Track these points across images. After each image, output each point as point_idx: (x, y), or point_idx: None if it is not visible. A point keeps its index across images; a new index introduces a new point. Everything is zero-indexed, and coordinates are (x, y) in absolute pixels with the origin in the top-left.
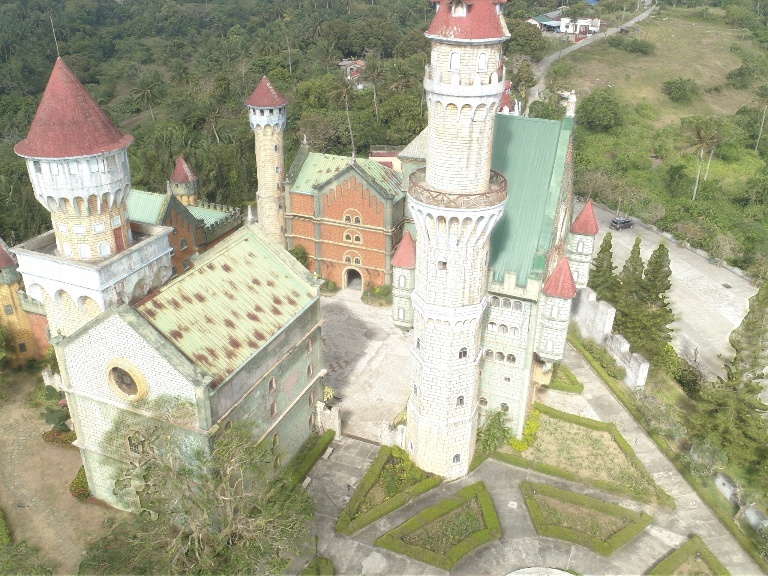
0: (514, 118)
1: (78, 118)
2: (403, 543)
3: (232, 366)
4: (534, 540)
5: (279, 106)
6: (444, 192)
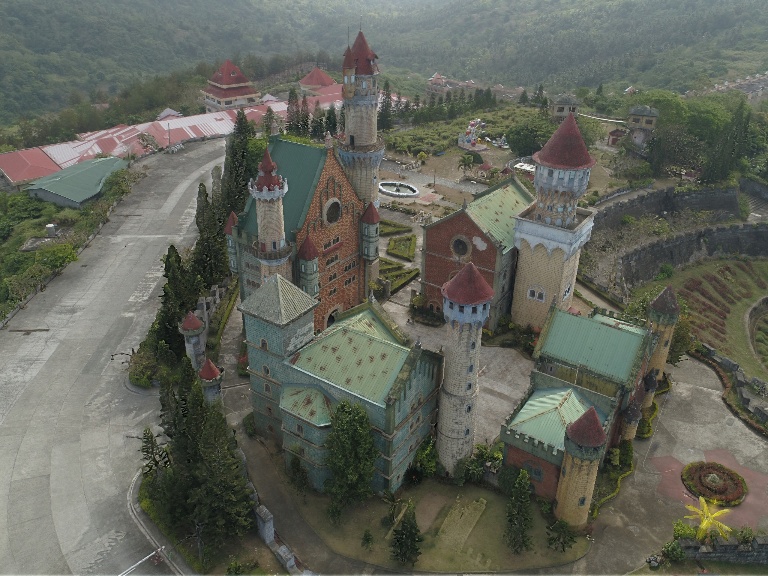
0: None
1: None
2: None
3: None
4: None
5: None
6: None
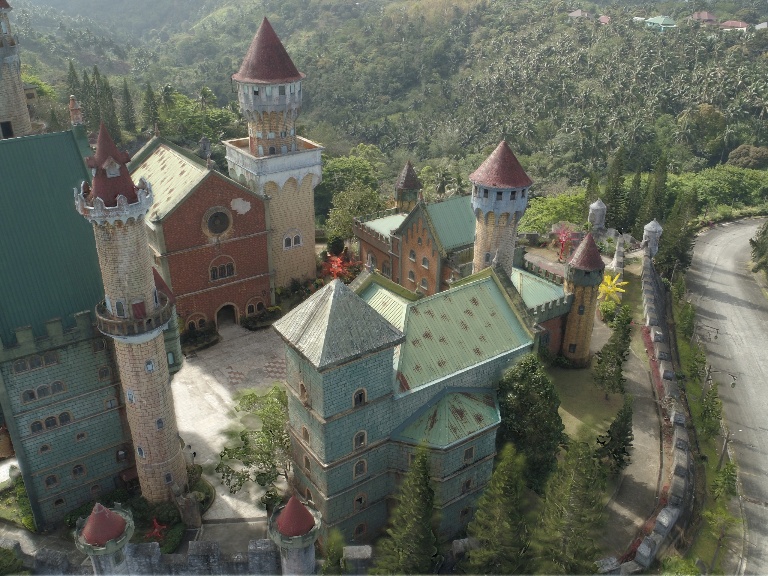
0: (8, 141)
1: None
2: None
3: None
4: None
5: None
6: None
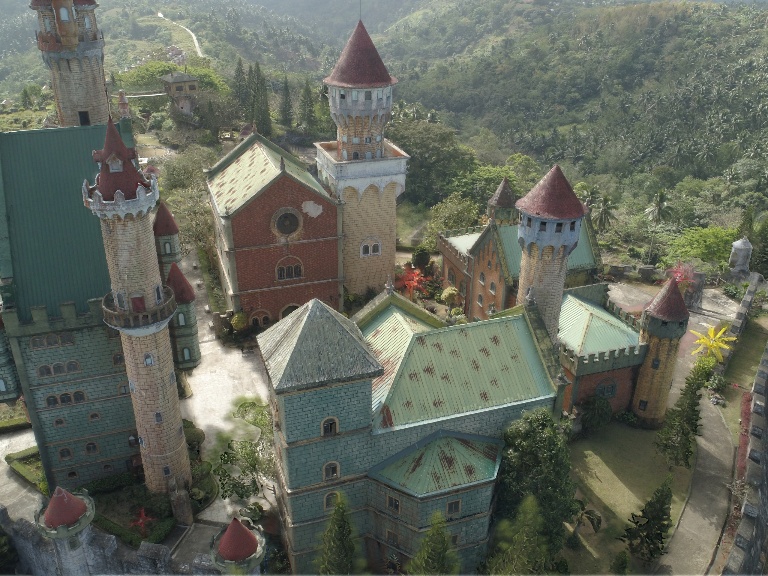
0: (60, 129)
1: None
2: None
3: None
4: None
5: None
6: None
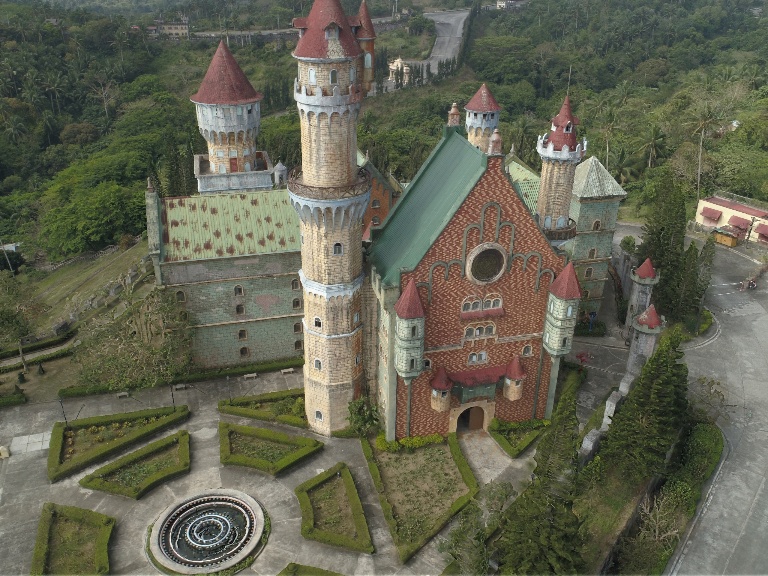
0: (470, 147)
1: (215, 80)
2: (227, 433)
3: (191, 256)
4: (291, 494)
5: (482, 112)
6: (303, 179)
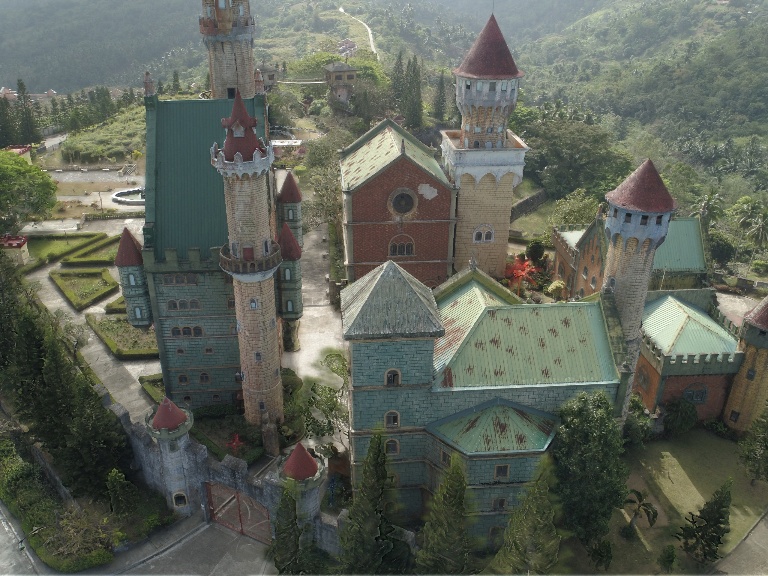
0: (206, 101)
1: None
2: None
3: None
4: None
5: None
6: None
